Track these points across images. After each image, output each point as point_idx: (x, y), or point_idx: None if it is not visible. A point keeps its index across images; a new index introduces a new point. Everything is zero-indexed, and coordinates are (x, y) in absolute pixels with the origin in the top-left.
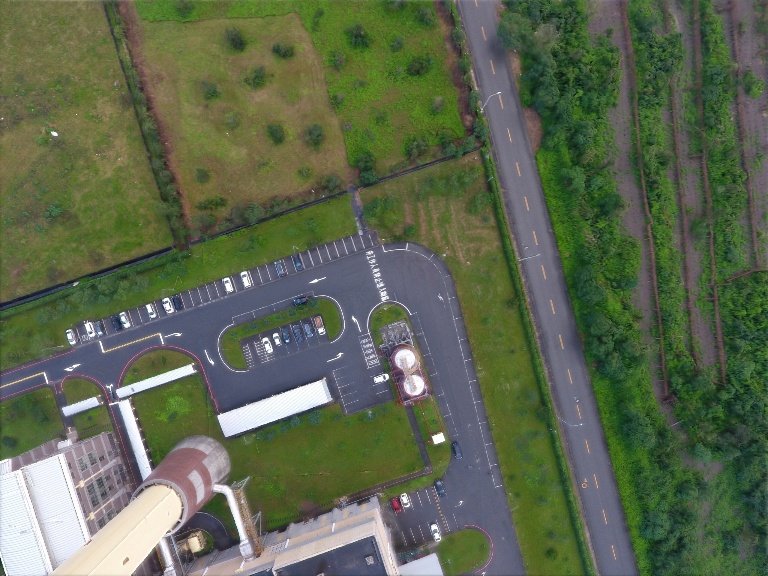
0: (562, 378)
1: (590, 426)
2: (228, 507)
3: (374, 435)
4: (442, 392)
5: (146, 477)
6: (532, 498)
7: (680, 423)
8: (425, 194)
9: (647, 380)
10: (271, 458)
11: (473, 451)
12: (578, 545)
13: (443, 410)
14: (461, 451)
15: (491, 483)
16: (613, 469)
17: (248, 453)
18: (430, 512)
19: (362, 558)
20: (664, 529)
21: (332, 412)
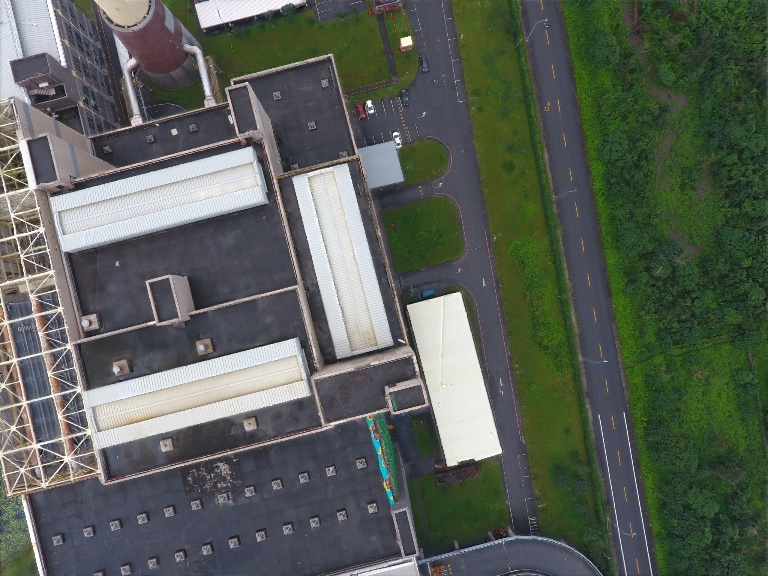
0: (533, 4)
1: (557, 52)
2: (199, 100)
3: (345, 42)
4: (414, 7)
5: (123, 60)
6: (494, 113)
7: (647, 54)
8: None
9: None
10: (244, 56)
11: (440, 66)
12: (536, 161)
13: (414, 25)
14: (428, 65)
15: (455, 97)
16: (577, 95)
17: (222, 50)
18: (393, 121)
19: (318, 82)
20: (622, 147)
21: (306, 18)
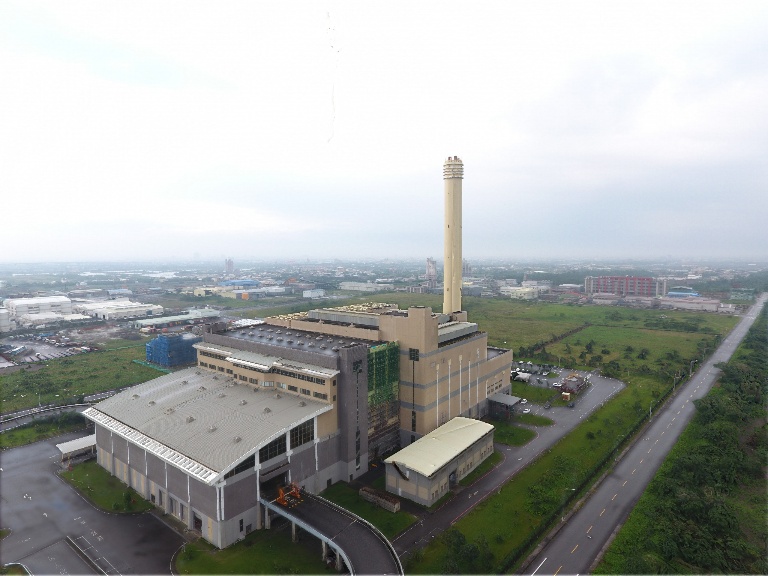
0: None
1: None
2: None
3: None
4: None
5: None
6: None
7: None
8: (635, 374)
9: (735, 430)
10: None
11: None
12: None
13: None
14: None
15: None
16: None
17: None
18: None
19: None
20: None
21: None
